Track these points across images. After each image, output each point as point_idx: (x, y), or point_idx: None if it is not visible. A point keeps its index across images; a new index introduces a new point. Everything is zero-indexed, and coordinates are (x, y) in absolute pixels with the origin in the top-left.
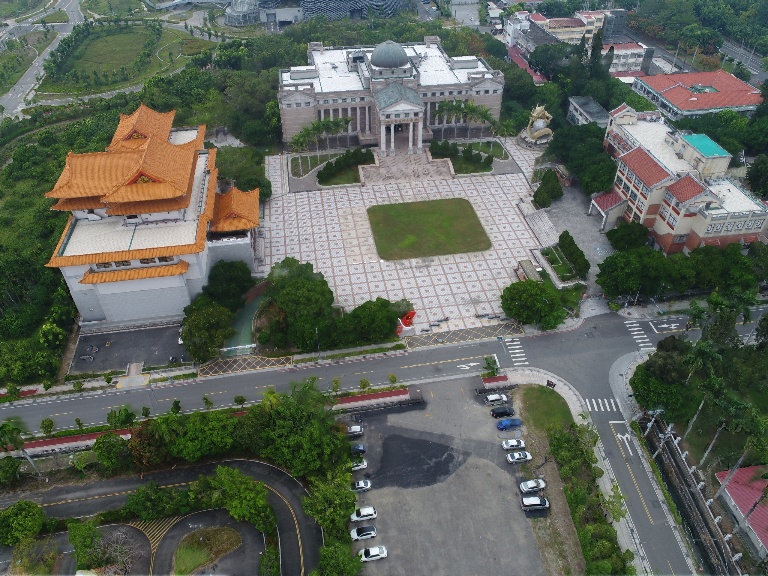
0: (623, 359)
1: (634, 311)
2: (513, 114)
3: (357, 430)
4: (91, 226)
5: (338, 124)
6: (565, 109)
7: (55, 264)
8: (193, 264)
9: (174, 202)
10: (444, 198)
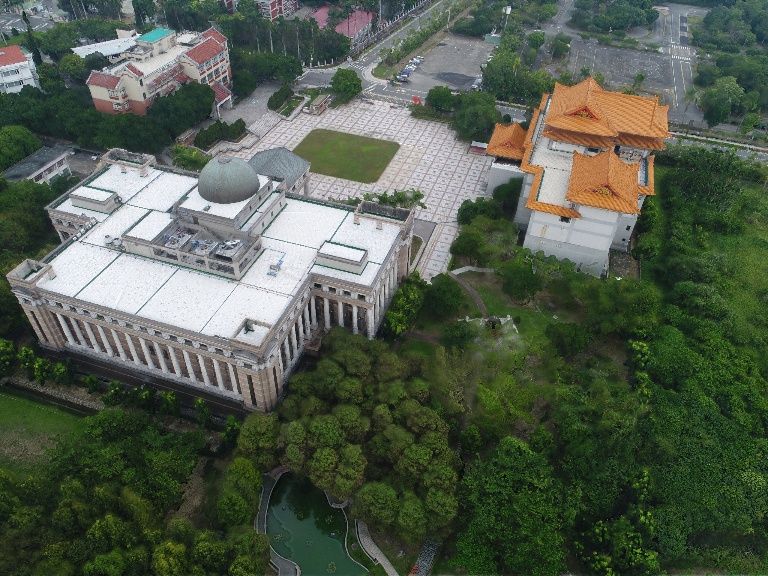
0: (325, 72)
1: None
2: None
3: None
4: None
5: None
6: None
7: None
8: None
9: None
10: None
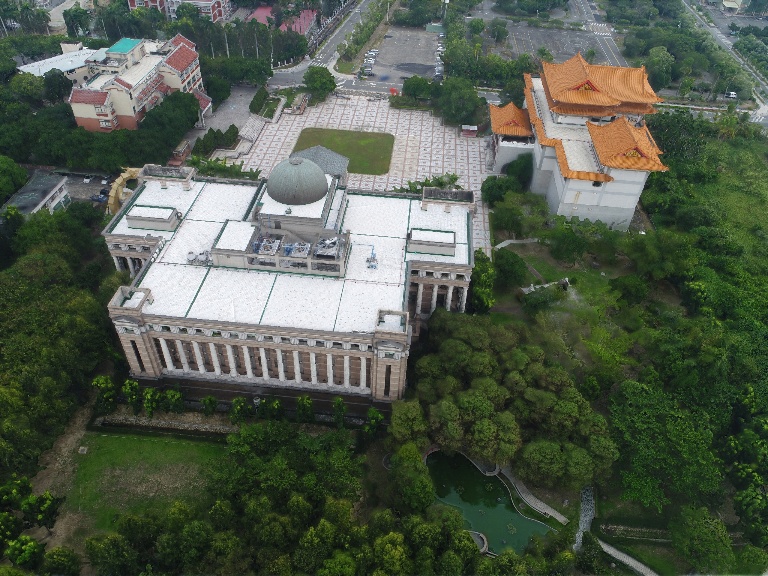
0: (289, 72)
1: None
2: None
3: None
4: None
5: None
6: (7, 263)
7: None
8: None
9: None
10: None
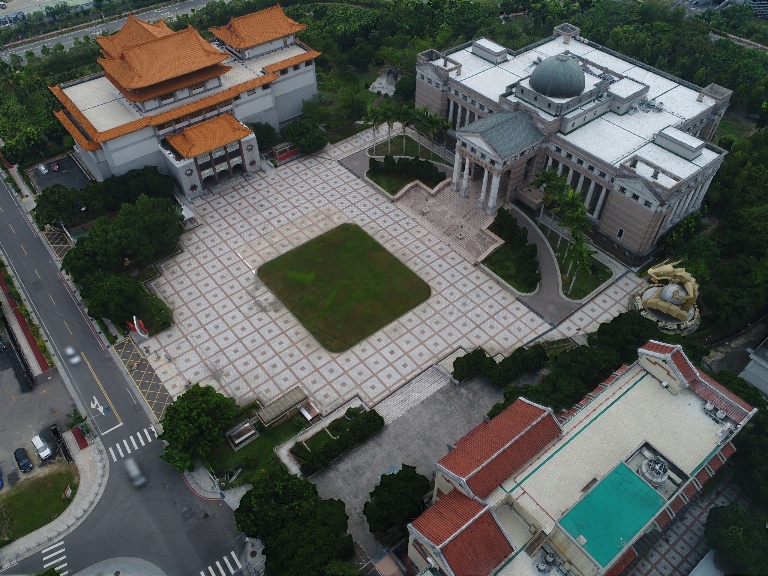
0: (150, 568)
1: (261, 559)
2: (677, 256)
3: None
4: None
5: (433, 123)
6: None
7: (54, 90)
8: (104, 150)
9: (134, 93)
10: (418, 273)
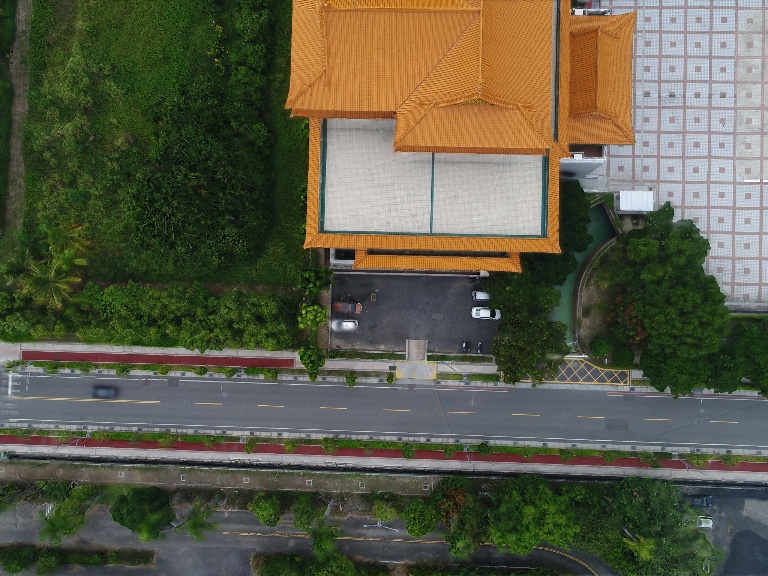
0: None
1: None
2: None
3: (708, 526)
4: (355, 136)
5: None
6: None
7: (318, 243)
8: None
9: None
10: None
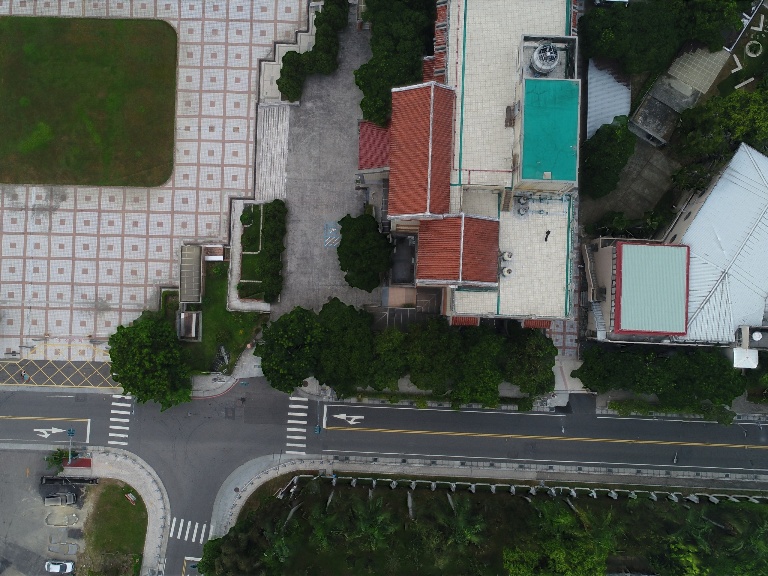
0: (253, 465)
1: (314, 381)
2: None
3: None
4: None
5: None
6: None
7: None
8: None
9: None
10: (135, 16)
